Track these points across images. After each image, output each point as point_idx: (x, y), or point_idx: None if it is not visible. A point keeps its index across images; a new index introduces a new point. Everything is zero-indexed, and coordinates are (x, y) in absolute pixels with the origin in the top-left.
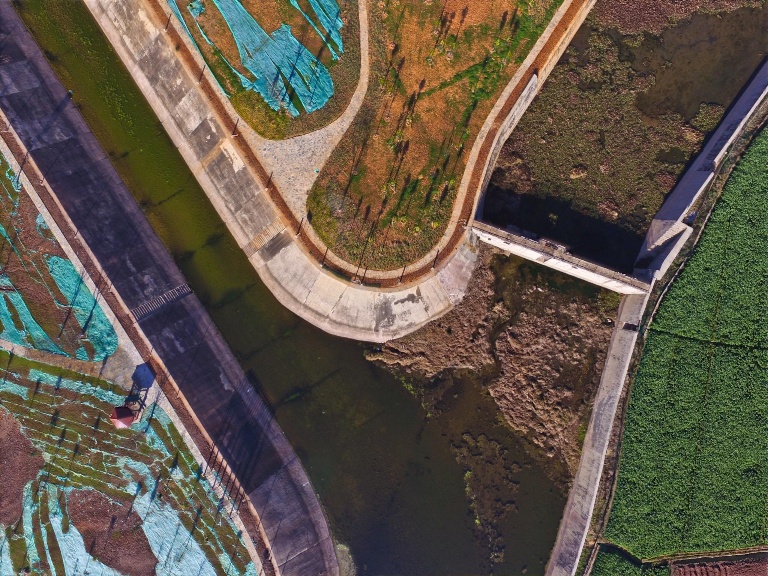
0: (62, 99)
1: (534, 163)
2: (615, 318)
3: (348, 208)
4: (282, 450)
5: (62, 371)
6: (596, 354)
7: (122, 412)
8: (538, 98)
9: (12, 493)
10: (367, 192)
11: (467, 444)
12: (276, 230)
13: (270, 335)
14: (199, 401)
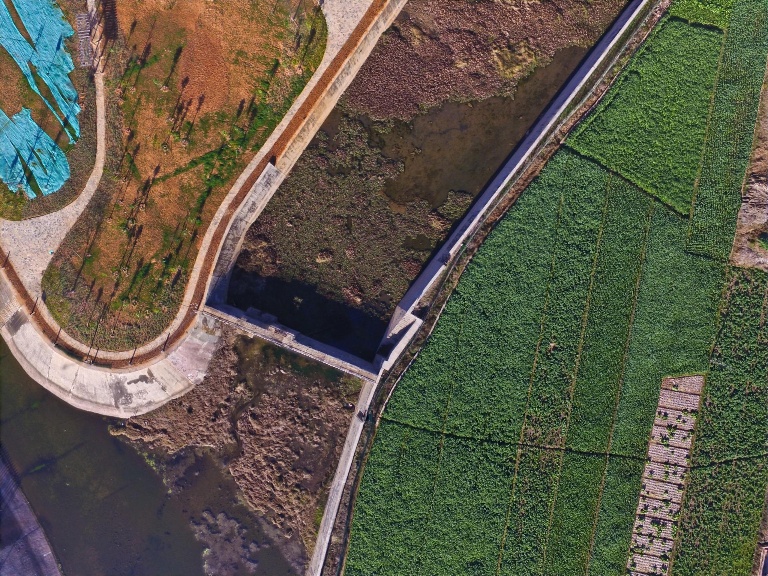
0: None
1: (280, 246)
2: (355, 403)
3: (81, 289)
4: (24, 520)
5: None
6: (336, 438)
7: None
8: (287, 182)
9: None
10: (100, 274)
11: (207, 522)
12: (15, 307)
13: (19, 406)
14: None
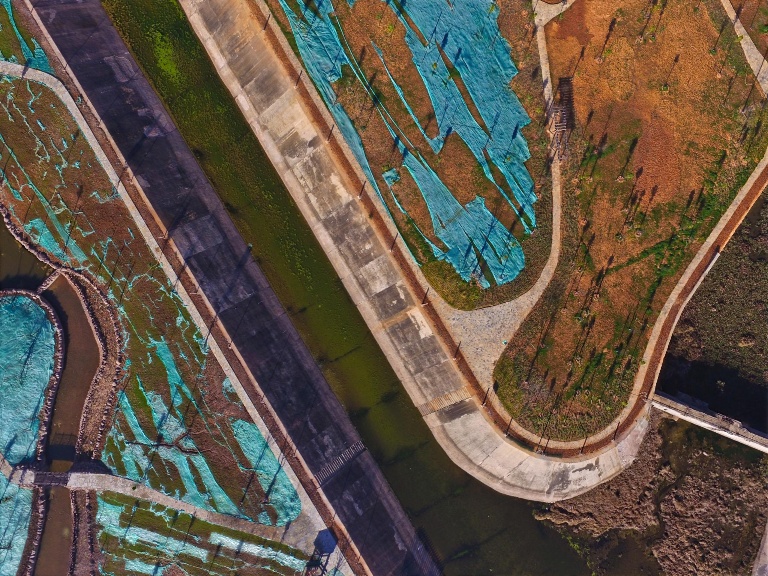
0: (243, 253)
1: (704, 331)
2: None
3: (534, 380)
4: None
5: (244, 535)
6: (756, 517)
7: None
8: None
9: None
10: (553, 364)
11: None
12: (460, 397)
13: (441, 493)
14: (378, 565)
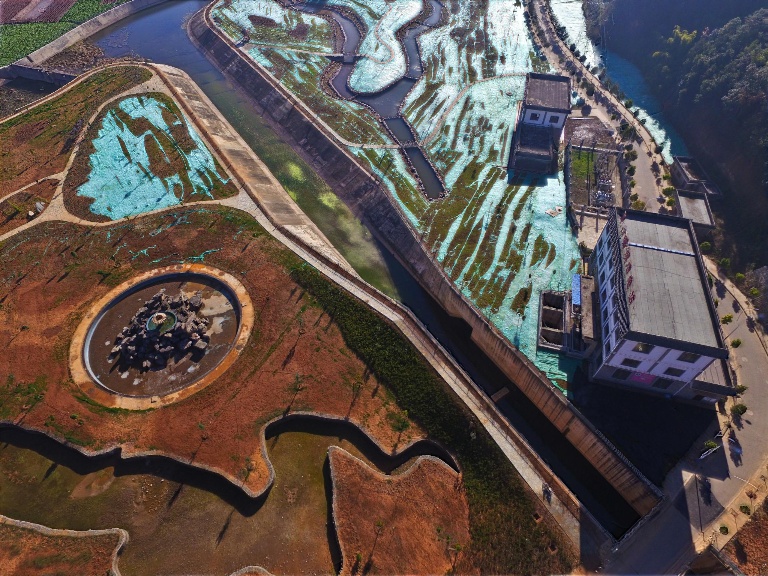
0: None
1: None
2: None
3: None
4: None
5: None
6: None
7: (244, 31)
8: None
9: (300, 28)
10: None
11: None
12: None
13: None
14: None
